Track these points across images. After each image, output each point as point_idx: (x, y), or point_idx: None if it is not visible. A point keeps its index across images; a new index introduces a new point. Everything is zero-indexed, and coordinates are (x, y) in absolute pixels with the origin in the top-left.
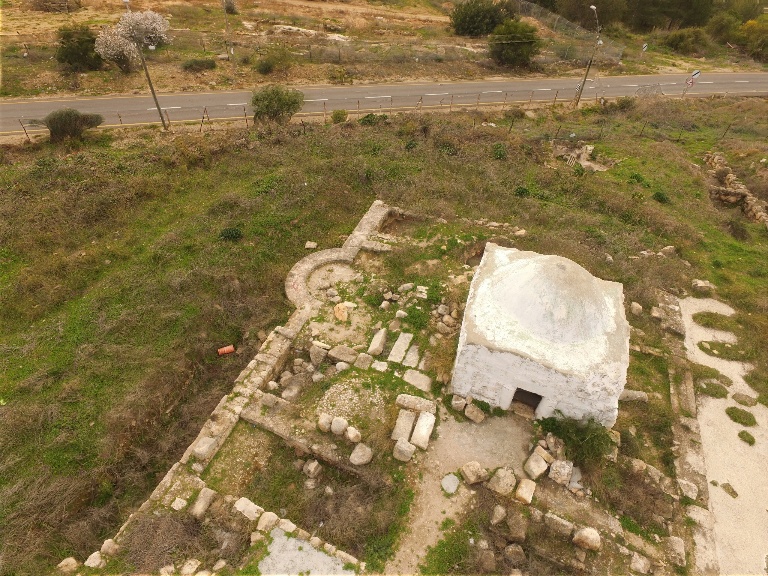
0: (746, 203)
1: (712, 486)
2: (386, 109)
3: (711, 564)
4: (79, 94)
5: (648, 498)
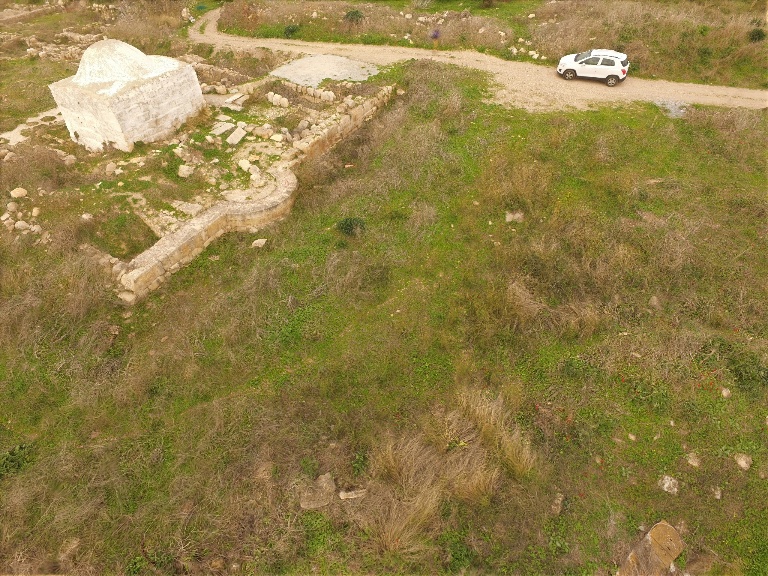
0: None
1: None
2: None
3: None
4: None
5: None
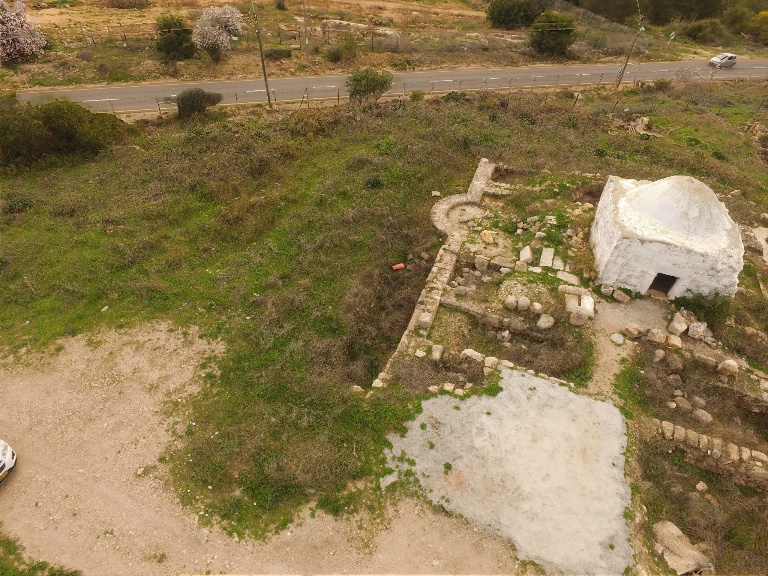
0: None
1: None
2: None
3: None
4: (181, 79)
5: None
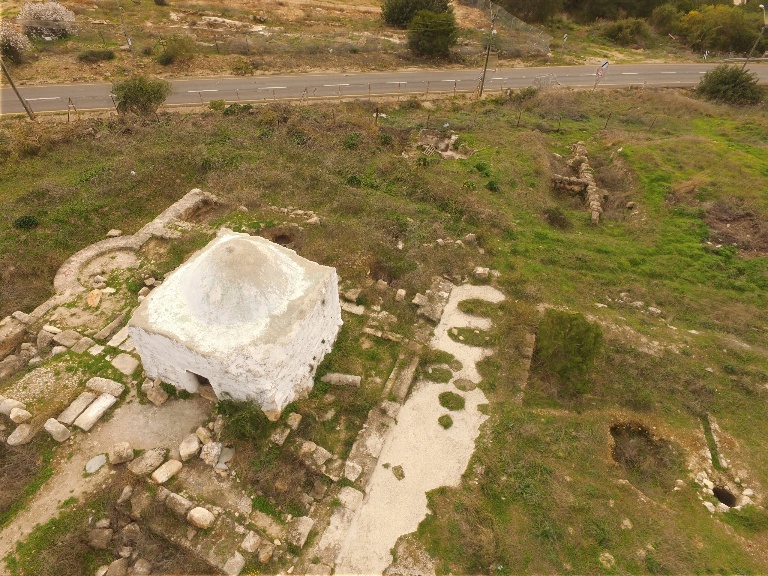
0: (587, 192)
1: (382, 468)
2: (275, 100)
3: (333, 544)
4: None
5: (308, 480)
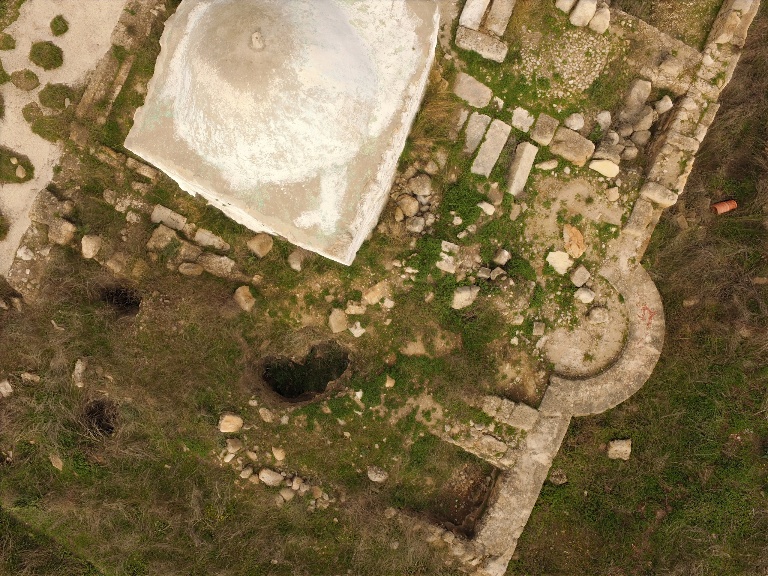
0: None
1: None
2: None
3: None
4: None
5: None
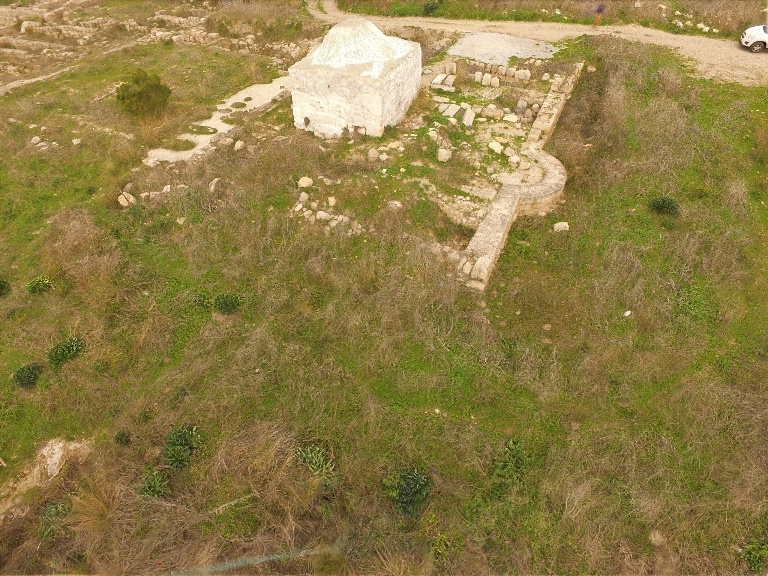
0: None
1: None
2: None
3: None
4: None
5: None
